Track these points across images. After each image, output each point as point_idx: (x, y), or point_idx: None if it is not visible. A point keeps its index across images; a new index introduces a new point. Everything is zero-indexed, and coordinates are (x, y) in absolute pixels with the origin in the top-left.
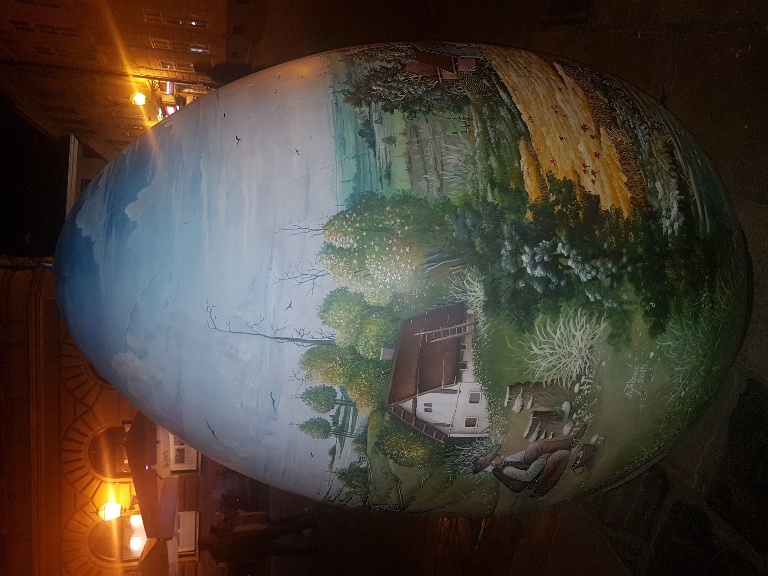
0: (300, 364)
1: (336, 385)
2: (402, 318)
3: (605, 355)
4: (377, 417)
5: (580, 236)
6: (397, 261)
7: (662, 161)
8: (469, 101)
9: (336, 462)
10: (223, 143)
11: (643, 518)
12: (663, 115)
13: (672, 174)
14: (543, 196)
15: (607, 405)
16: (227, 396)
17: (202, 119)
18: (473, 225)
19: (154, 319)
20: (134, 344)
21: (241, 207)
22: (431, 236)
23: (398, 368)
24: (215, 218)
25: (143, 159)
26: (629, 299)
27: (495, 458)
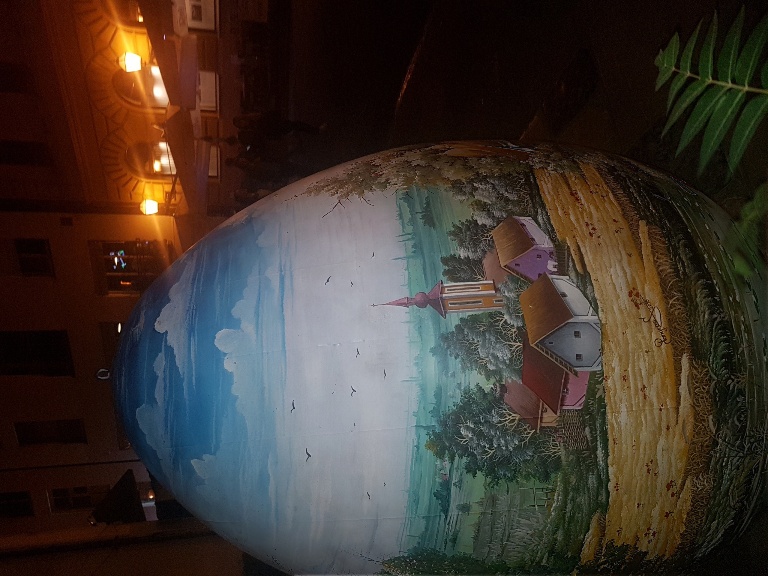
0: None
1: None
2: None
3: None
4: None
5: None
6: None
7: (733, 497)
8: (560, 465)
9: None
10: (292, 451)
11: None
12: None
13: (736, 506)
14: (594, 559)
15: None
16: None
17: (268, 395)
18: None
19: (224, 535)
20: None
21: (308, 523)
22: None
23: None
24: (283, 520)
25: (204, 413)
26: None
27: None
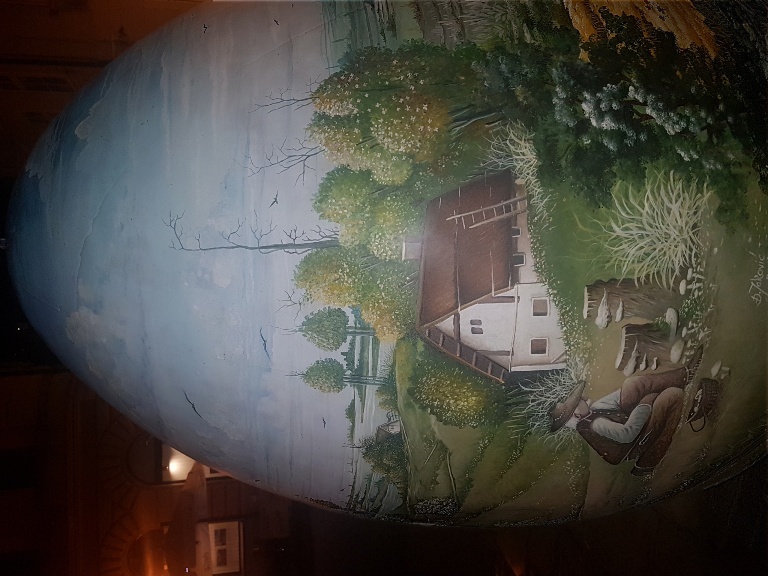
0: (295, 280)
1: (346, 305)
2: (427, 198)
3: (716, 238)
4: (406, 348)
5: (657, 78)
6: (413, 123)
7: (745, 5)
8: None
9: (358, 428)
10: (188, 35)
11: None
12: None
13: (761, 18)
14: (599, 33)
15: (728, 314)
16: (205, 345)
17: (167, 26)
18: (510, 71)
19: (108, 253)
20: (87, 294)
21: (208, 92)
22: (455, 88)
23: (428, 270)
24: (177, 110)
25: (99, 78)
26: (737, 159)
27: (579, 404)
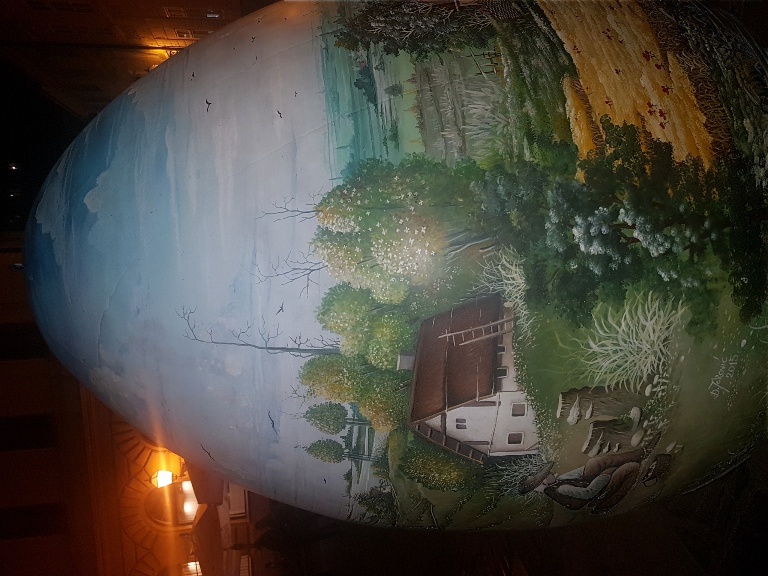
0: (300, 378)
1: (345, 402)
2: (421, 317)
3: (684, 348)
4: (398, 437)
5: (648, 198)
6: (411, 246)
7: (750, 92)
8: (495, 32)
9: (354, 487)
10: (191, 109)
11: (718, 509)
12: (746, 33)
13: (764, 108)
14: (597, 149)
15: (687, 408)
16: (219, 417)
17: (168, 82)
18: (507, 193)
19: (126, 330)
20: (108, 358)
21: (215, 188)
22: (453, 211)
23: (420, 379)
24: (185, 204)
25: (102, 136)
26: (714, 275)
27: (547, 477)
